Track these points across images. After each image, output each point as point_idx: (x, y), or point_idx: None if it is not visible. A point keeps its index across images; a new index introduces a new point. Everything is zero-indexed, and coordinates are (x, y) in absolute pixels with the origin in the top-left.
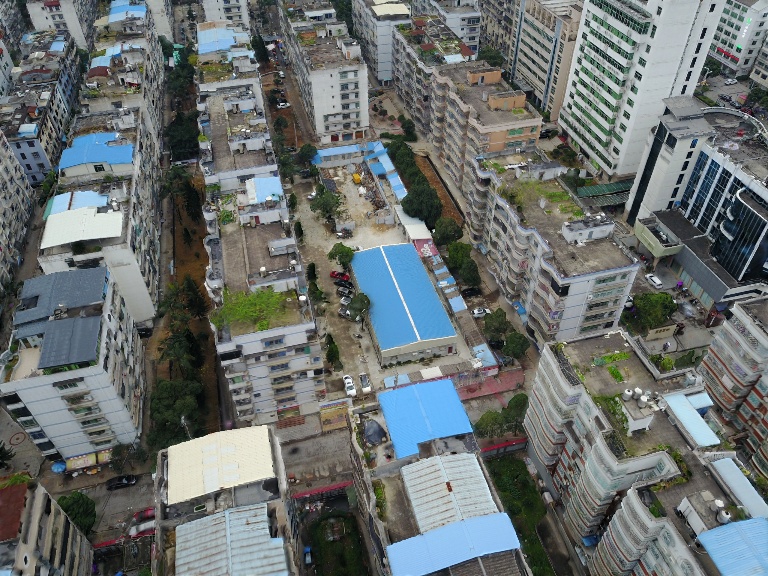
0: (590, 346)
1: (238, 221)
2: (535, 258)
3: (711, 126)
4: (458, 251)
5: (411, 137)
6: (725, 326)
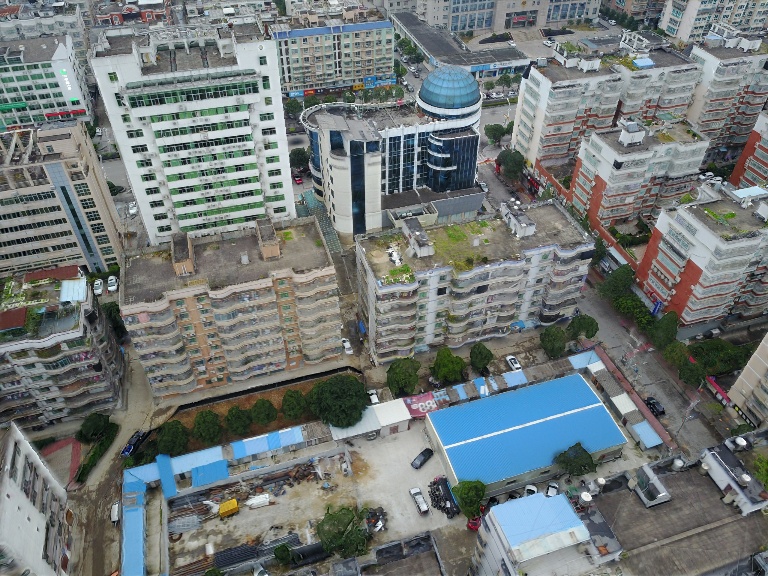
0: (708, 224)
1: (606, 568)
2: (529, 271)
3: (358, 120)
4: (452, 362)
5: (113, 429)
6: (618, 174)
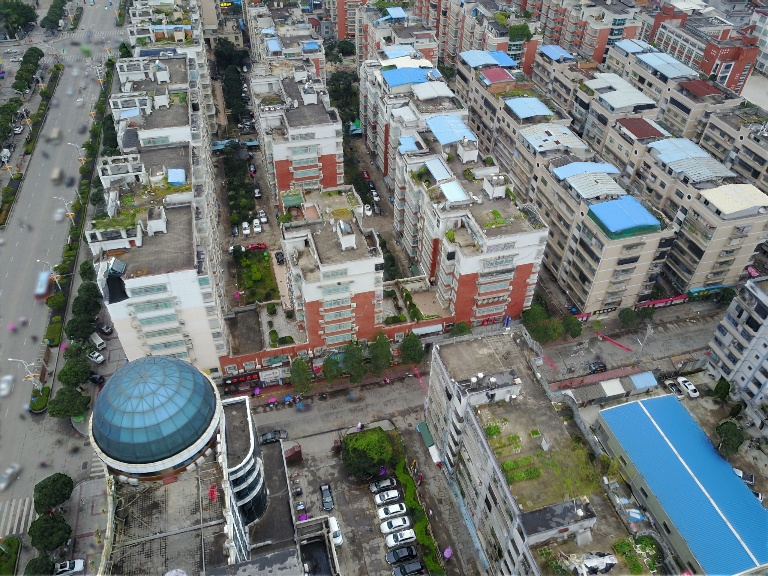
0: (513, 231)
1: None
2: None
3: None
4: None
5: None
6: None
